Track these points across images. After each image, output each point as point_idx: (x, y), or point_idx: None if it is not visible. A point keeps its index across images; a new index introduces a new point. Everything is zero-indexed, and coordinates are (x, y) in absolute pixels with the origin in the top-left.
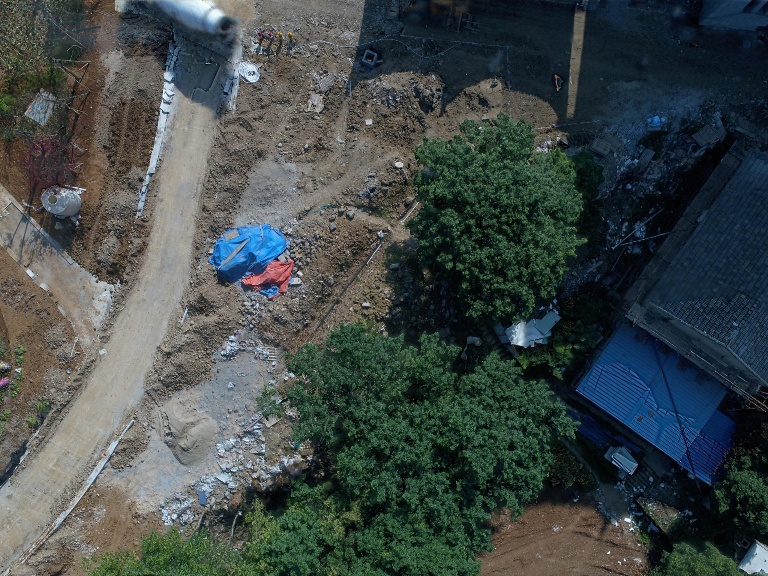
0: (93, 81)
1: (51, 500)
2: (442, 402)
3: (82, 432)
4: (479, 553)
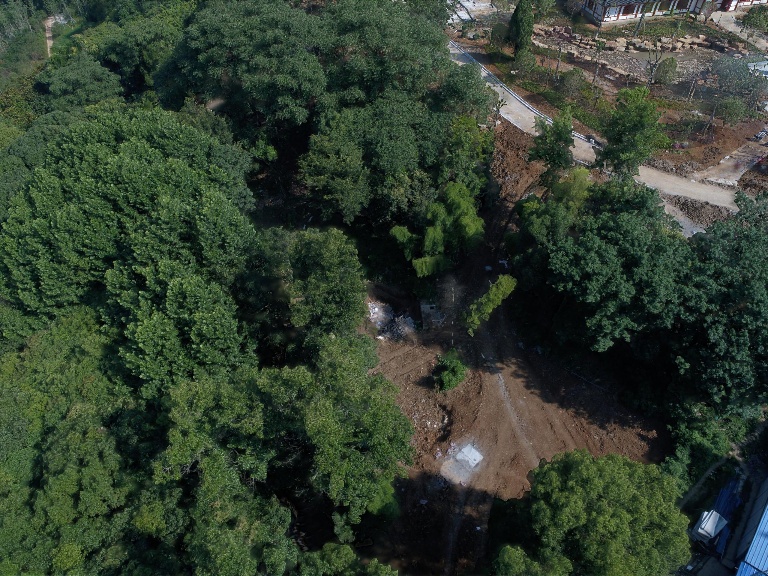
0: None
1: (593, 161)
2: None
3: None
4: (567, 412)
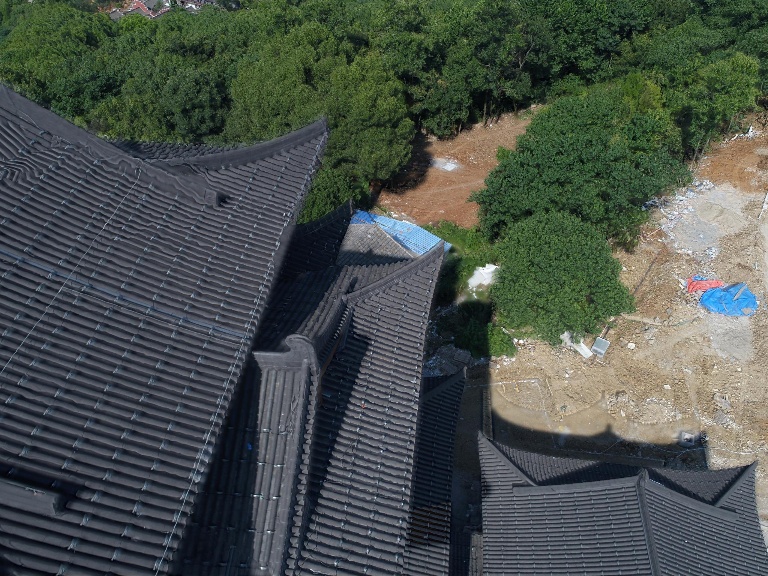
0: None
1: None
2: (570, 187)
3: None
4: None
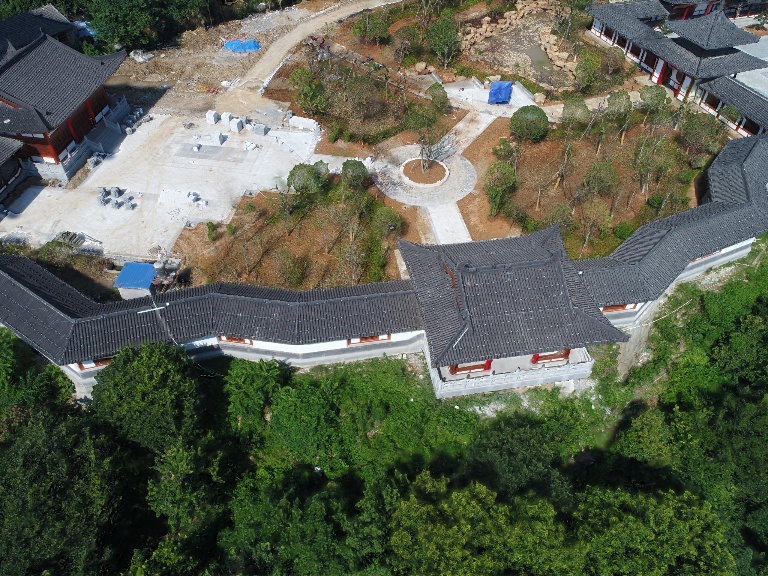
0: None
1: None
2: None
3: None
4: None
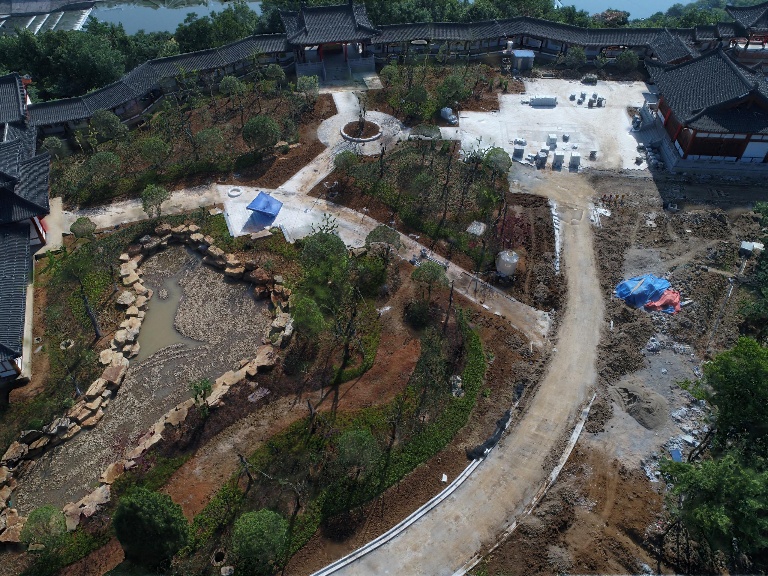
0: (508, 216)
1: (540, 459)
2: None
3: (554, 404)
4: None
